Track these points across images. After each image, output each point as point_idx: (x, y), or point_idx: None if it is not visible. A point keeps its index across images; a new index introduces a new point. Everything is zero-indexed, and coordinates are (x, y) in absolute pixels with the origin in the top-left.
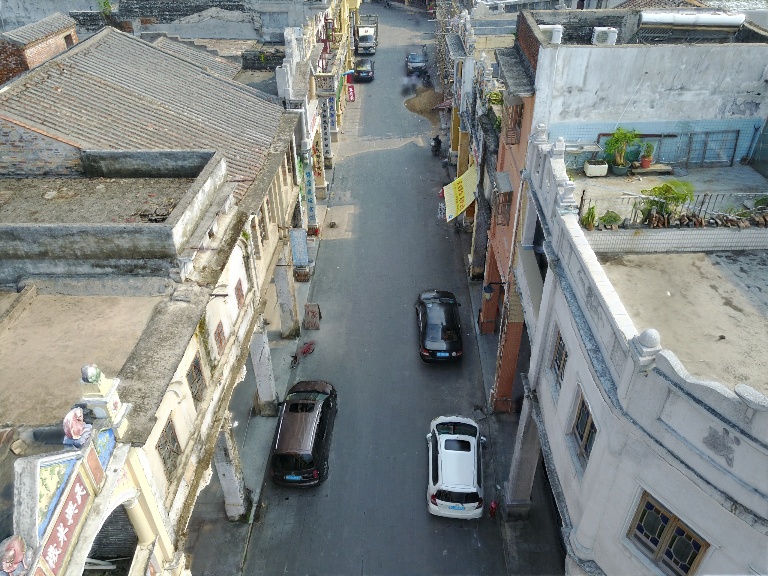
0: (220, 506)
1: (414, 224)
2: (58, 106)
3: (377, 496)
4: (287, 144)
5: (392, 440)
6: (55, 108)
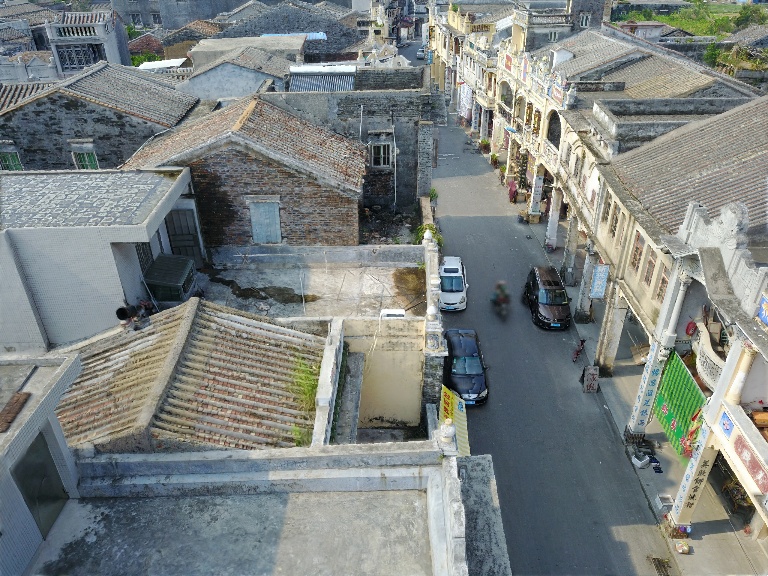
0: (578, 281)
1: (516, 563)
2: (764, 118)
3: (493, 286)
4: (629, 208)
5: (490, 308)
6: (761, 116)
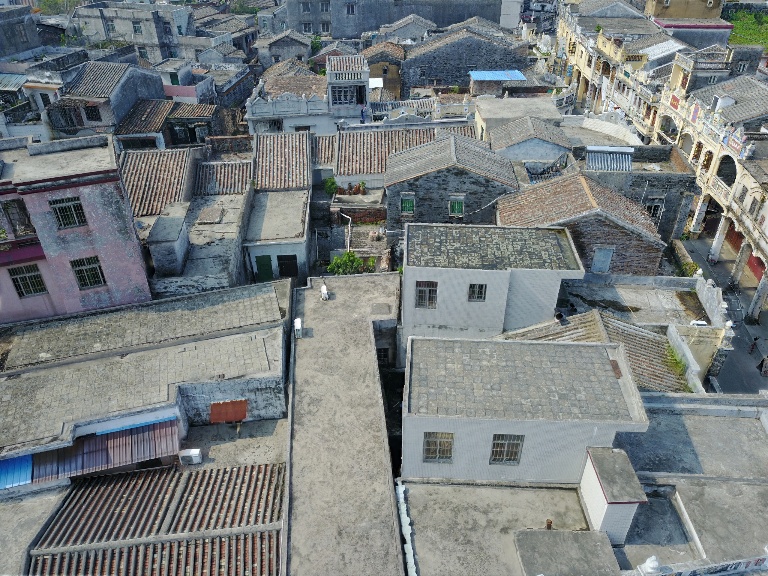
0: (741, 291)
1: None
2: None
3: None
4: None
5: None
6: None
